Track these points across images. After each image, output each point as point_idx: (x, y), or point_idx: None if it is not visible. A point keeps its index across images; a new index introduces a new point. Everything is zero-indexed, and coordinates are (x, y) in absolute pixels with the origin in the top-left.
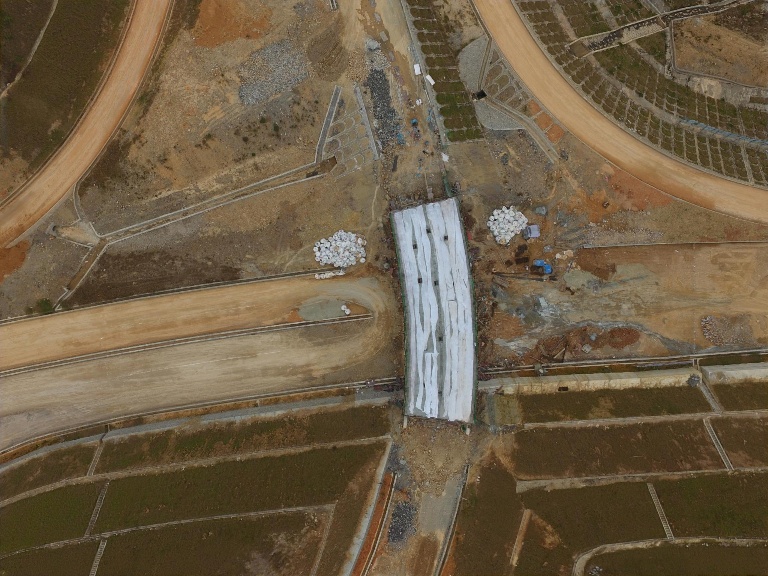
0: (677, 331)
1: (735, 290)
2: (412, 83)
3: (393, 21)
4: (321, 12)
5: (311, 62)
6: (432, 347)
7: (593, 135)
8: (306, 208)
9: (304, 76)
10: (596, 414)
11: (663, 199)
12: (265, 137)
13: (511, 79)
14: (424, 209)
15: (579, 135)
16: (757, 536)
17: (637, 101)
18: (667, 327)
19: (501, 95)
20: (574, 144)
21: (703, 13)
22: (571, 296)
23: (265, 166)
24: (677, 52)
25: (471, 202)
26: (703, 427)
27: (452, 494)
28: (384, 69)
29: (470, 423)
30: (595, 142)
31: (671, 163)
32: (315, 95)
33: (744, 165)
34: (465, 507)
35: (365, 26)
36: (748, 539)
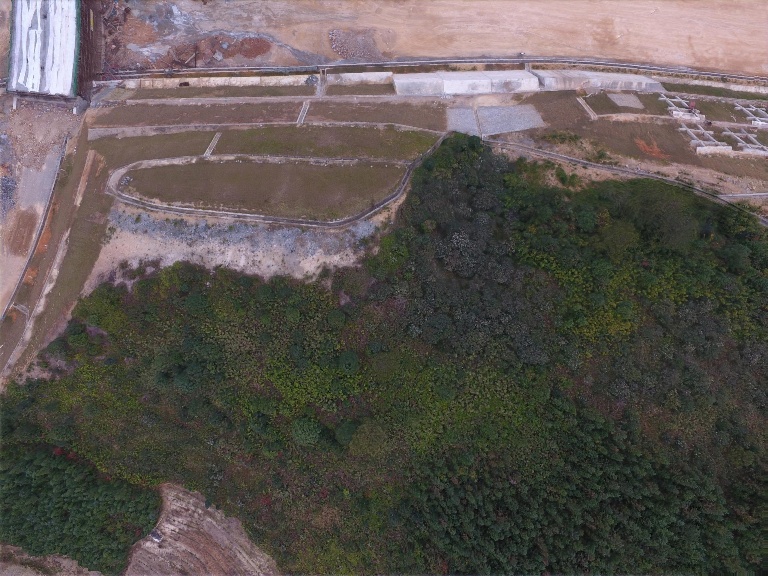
0: (307, 43)
1: (361, 6)
2: None
3: None
4: None
5: None
6: (36, 24)
7: None
8: None
9: None
10: (201, 96)
11: None
12: None
13: None
14: None
15: None
16: (290, 155)
17: None
18: (297, 39)
19: None
20: None
21: None
22: (203, 6)
23: None
24: None
25: None
26: (299, 106)
27: (52, 167)
28: None
29: (71, 97)
30: None
31: None
32: None
33: None
34: (61, 177)
35: None
36: (280, 157)
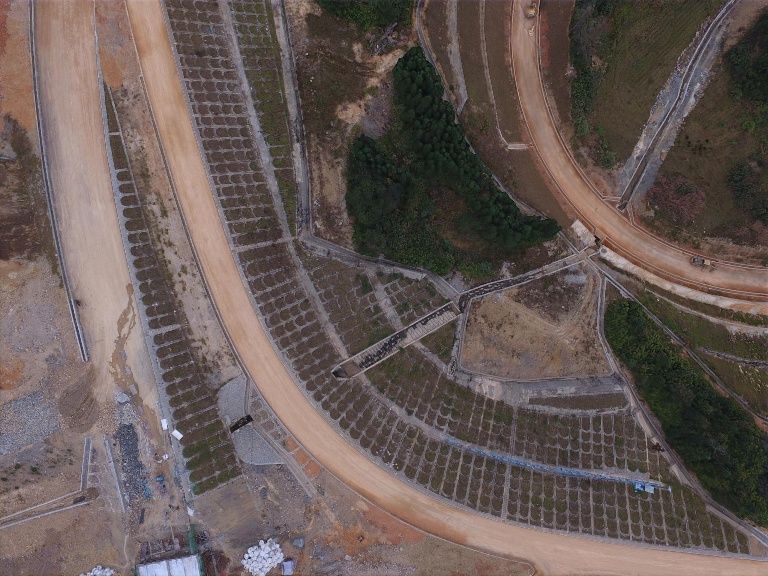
0: None
1: None
2: (160, 437)
3: (143, 375)
4: (71, 366)
5: (62, 415)
6: None
7: (349, 471)
8: (71, 536)
9: (55, 428)
10: None
11: (416, 535)
12: (25, 475)
13: (270, 415)
14: (167, 564)
15: (335, 471)
16: None
17: (406, 419)
18: None
19: (264, 425)
20: (329, 481)
21: (505, 287)
22: None
23: (29, 497)
24: (464, 346)
25: (220, 548)
26: None
27: None
28: (133, 422)
29: None
30: (351, 478)
31: (426, 498)
32: (67, 445)
33: (503, 492)
34: None
35: (116, 379)
36: None
